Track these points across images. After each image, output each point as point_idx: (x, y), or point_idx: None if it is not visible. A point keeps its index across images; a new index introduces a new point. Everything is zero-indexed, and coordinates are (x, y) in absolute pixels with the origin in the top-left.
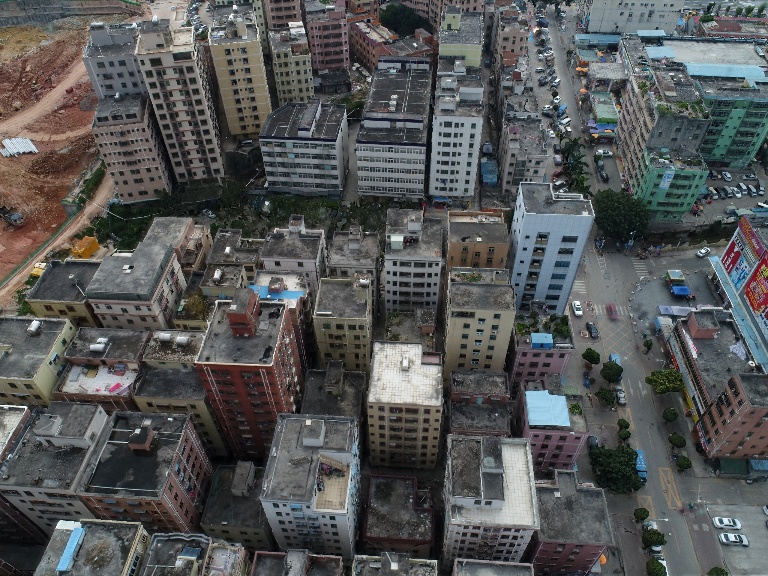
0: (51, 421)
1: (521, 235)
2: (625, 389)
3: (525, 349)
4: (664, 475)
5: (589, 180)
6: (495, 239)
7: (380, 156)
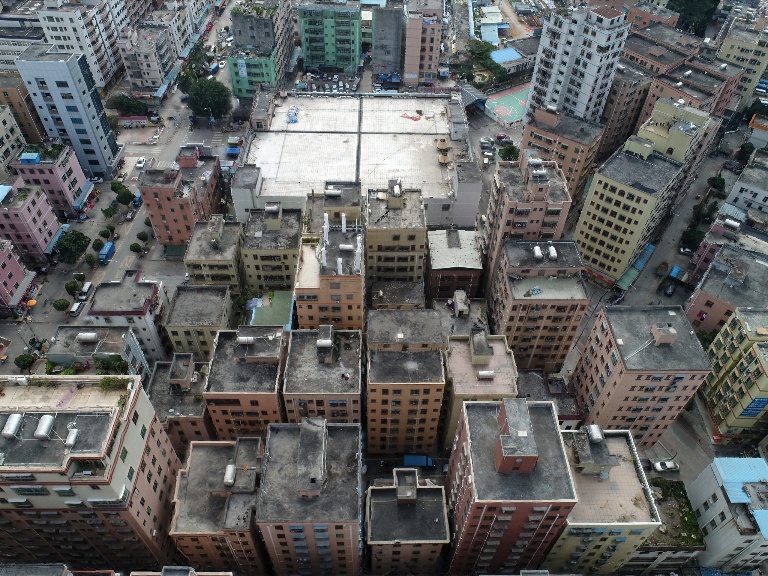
0: None
1: (24, 81)
2: (140, 211)
3: (16, 165)
4: (127, 260)
5: (222, 81)
6: (8, 86)
7: (8, 49)
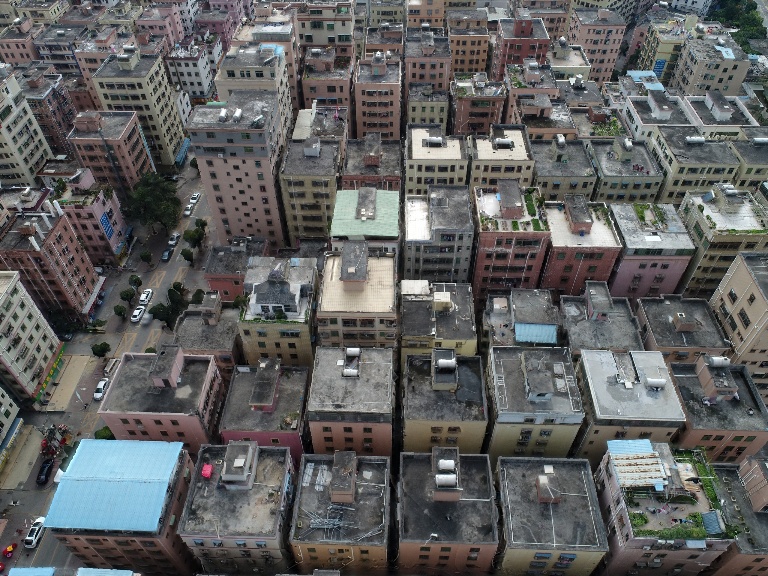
0: None
1: None
2: None
3: None
4: None
5: None
6: None
7: None
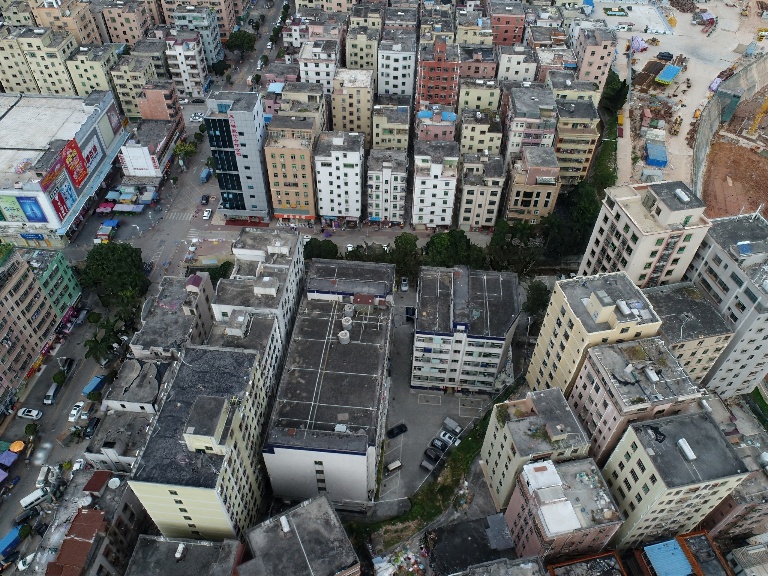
0: (518, 45)
1: None
2: None
3: None
4: None
5: (90, 366)
6: (281, 119)
7: None
